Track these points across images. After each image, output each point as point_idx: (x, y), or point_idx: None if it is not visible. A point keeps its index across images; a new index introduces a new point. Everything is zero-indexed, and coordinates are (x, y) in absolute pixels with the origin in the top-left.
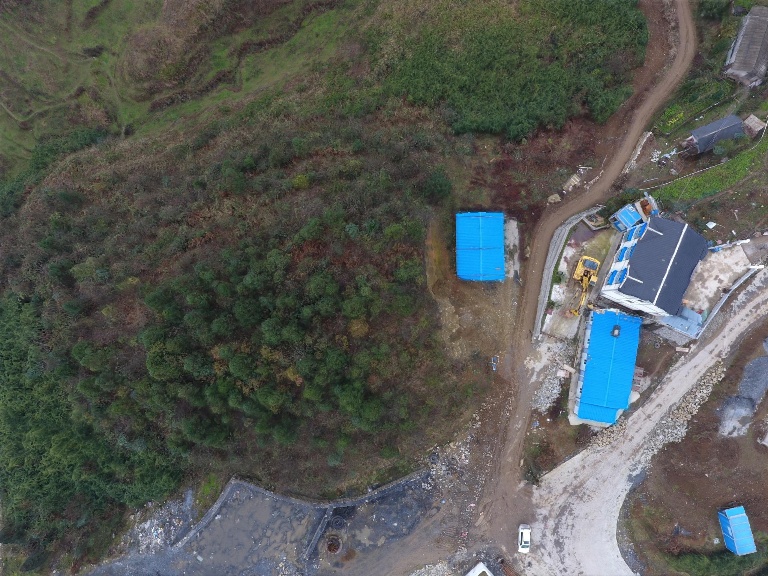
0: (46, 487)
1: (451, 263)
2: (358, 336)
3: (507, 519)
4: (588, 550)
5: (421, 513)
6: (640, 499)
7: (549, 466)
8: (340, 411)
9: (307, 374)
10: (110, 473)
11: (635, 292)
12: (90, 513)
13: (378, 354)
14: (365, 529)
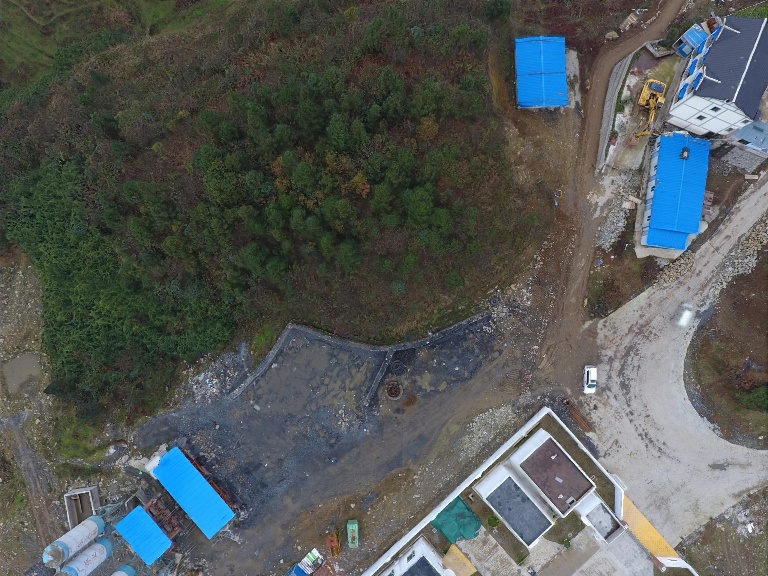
0: (96, 341)
1: (510, 95)
2: (428, 138)
3: (571, 361)
4: (654, 392)
5: (483, 357)
6: (709, 335)
7: (614, 304)
8: (407, 225)
9: (376, 176)
10: (161, 328)
11: (712, 92)
12: (143, 365)
13: (449, 156)
14: (426, 374)
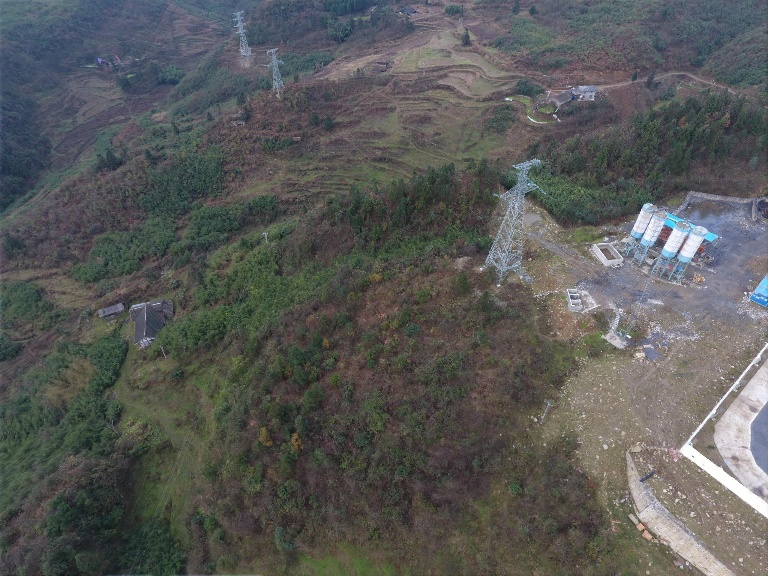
0: None
1: None
2: None
3: None
4: None
5: None
6: None
7: None
8: None
9: (735, 115)
10: None
11: None
12: None
13: None
14: None
